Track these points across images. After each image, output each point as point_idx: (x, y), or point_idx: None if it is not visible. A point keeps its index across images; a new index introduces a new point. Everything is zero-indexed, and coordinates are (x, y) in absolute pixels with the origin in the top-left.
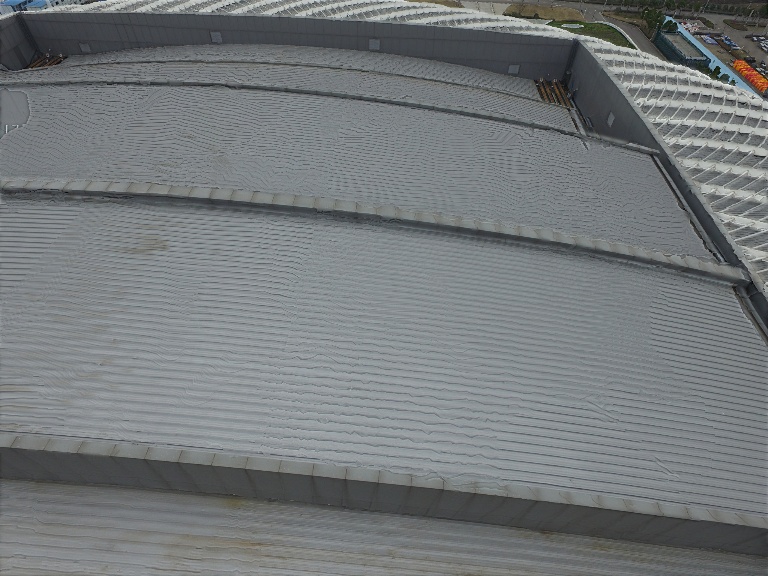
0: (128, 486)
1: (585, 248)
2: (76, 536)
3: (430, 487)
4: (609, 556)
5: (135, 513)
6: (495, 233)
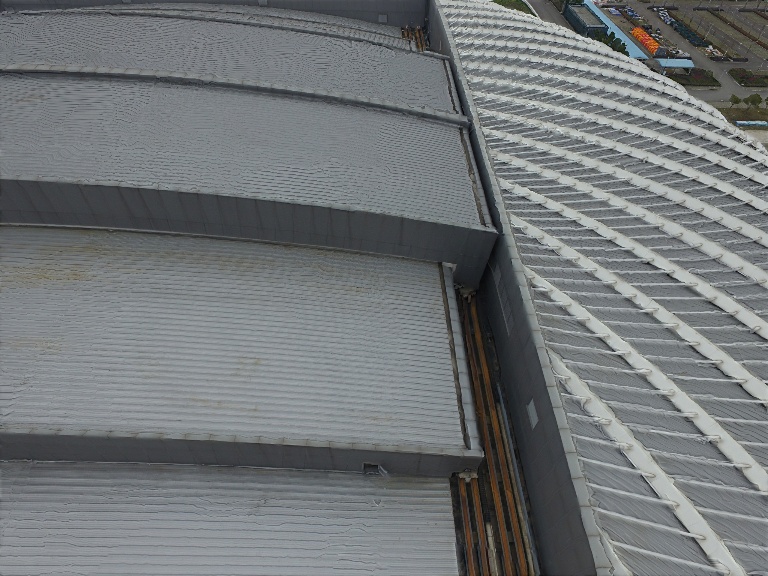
0: (17, 227)
1: (348, 99)
2: None
3: (189, 191)
4: (325, 256)
5: (21, 238)
6: (284, 90)
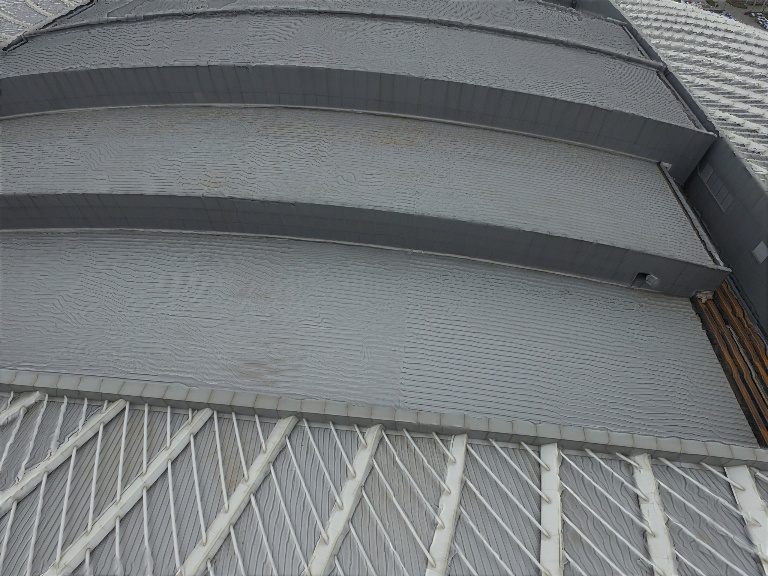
0: (356, 114)
1: (572, 43)
2: (341, 122)
3: (498, 87)
4: None
5: None
6: (524, 33)
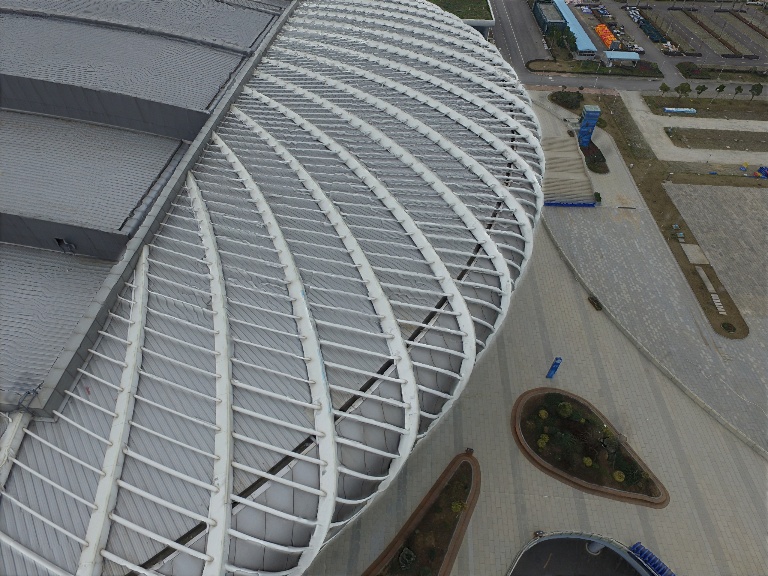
0: None
1: (152, 30)
2: None
3: None
4: (92, 128)
5: None
6: (104, 22)
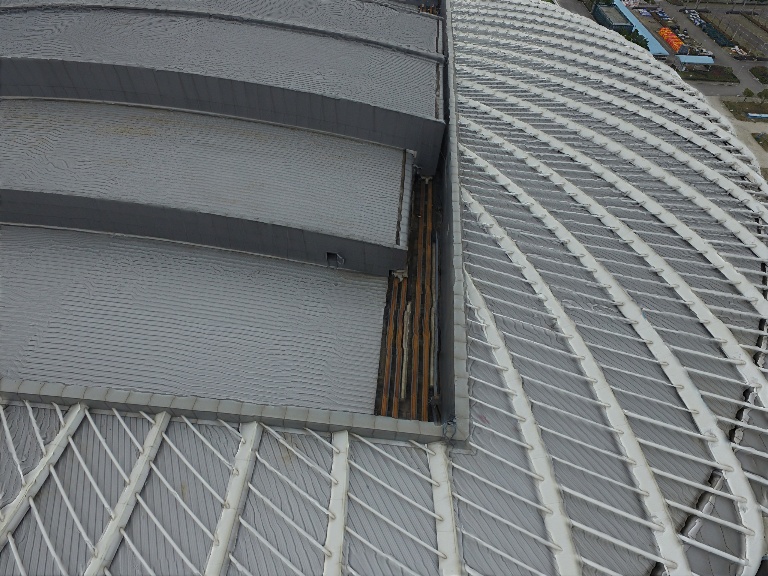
0: (109, 105)
1: (350, 36)
2: (86, 113)
3: (225, 78)
4: None
5: (111, 110)
6: (302, 27)
